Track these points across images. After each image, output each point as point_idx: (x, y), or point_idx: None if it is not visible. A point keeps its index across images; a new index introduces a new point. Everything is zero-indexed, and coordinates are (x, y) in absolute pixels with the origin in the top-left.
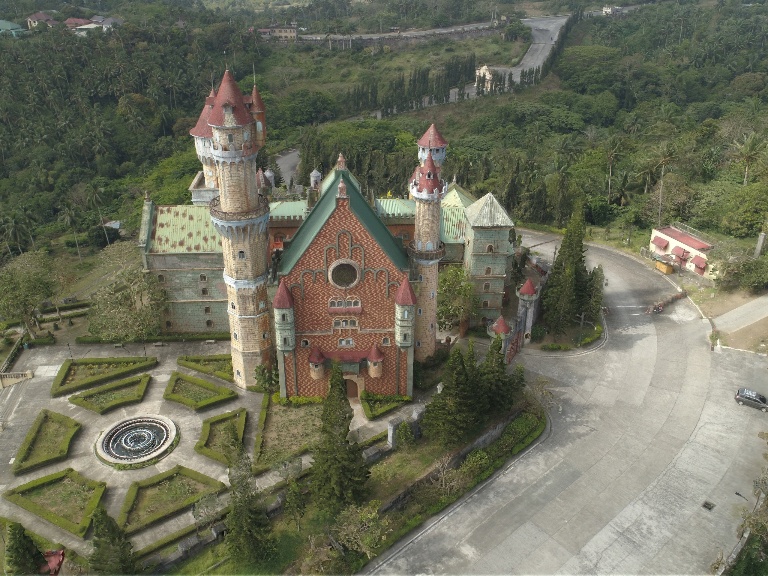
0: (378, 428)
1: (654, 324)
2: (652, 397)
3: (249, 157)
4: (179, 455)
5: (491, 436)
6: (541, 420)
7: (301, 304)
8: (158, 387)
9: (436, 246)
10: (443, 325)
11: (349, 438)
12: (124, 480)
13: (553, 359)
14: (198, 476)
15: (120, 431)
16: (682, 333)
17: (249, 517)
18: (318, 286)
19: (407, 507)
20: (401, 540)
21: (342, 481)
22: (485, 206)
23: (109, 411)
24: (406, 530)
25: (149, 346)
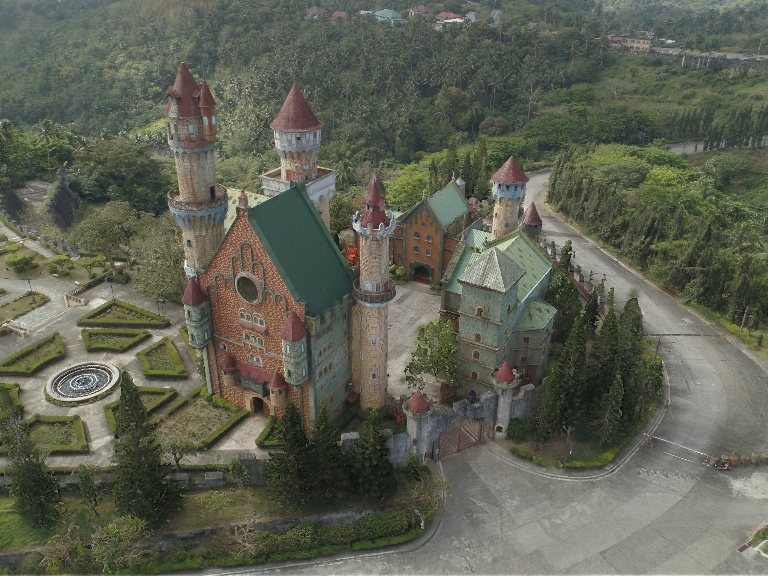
0: (257, 458)
1: (696, 481)
2: (585, 568)
3: (193, 150)
4: (94, 408)
5: (353, 518)
6: (417, 527)
7: (218, 306)
8: (147, 345)
9: (378, 288)
10: (414, 381)
11: (223, 455)
12: (40, 410)
13: (514, 468)
14: (79, 431)
15: (82, 370)
16: (722, 509)
17: (19, 479)
18: (229, 293)
19: (198, 545)
20: (171, 574)
21: (133, 487)
22: (481, 260)
23: (95, 351)
24: (179, 566)
25: (180, 309)
